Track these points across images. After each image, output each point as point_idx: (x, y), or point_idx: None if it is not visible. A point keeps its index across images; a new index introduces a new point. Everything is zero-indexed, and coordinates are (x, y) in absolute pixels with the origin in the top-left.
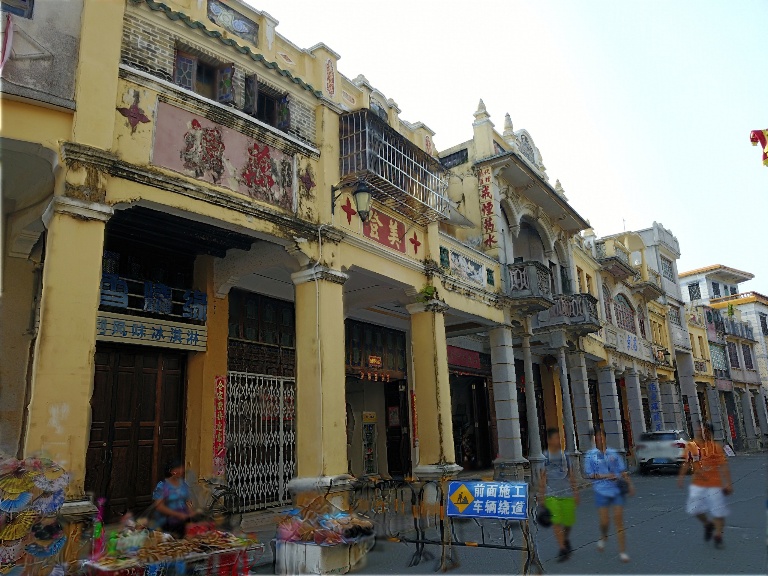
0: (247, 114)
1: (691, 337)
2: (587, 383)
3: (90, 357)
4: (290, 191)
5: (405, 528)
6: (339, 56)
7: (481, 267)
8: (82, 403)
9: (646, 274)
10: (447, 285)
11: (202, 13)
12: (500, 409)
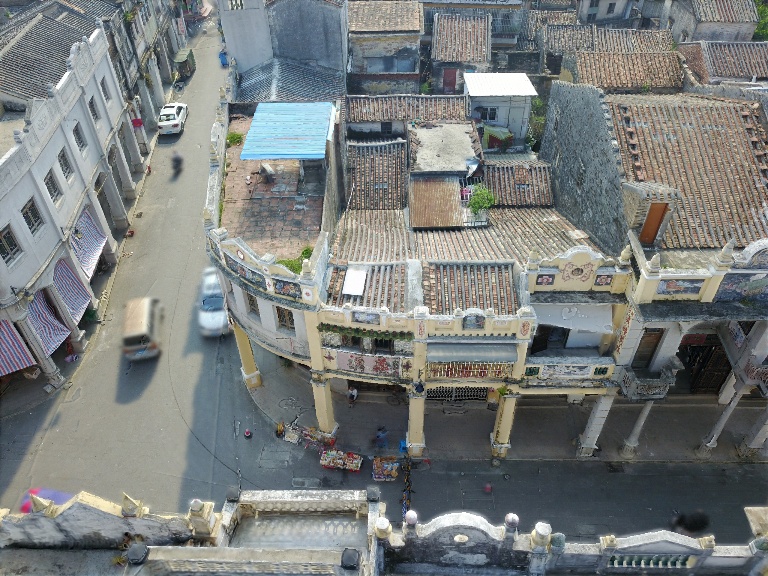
0: (371, 354)
1: None
2: None
3: (326, 411)
4: (398, 370)
5: (456, 458)
6: (428, 319)
7: (590, 366)
8: (326, 418)
9: None
10: (531, 382)
11: (349, 323)
12: (589, 421)
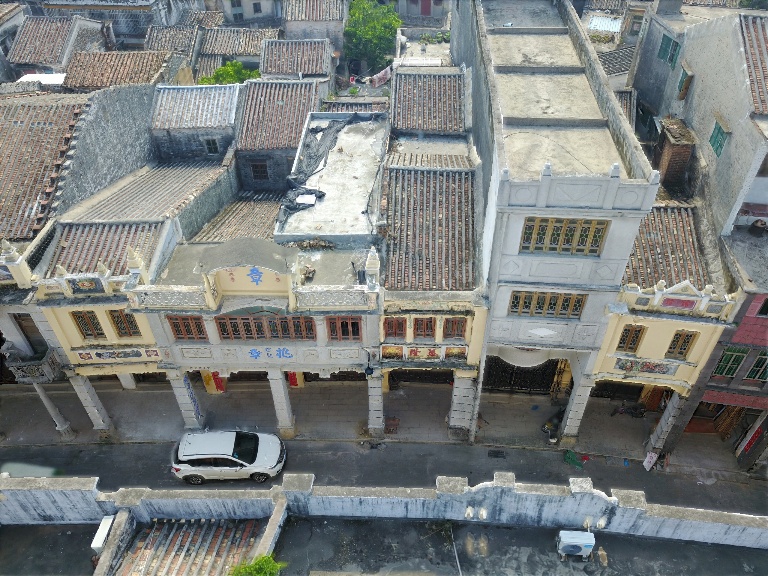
0: None
1: (645, 327)
2: (87, 394)
3: None
4: None
5: None
6: None
7: None
8: None
9: (289, 301)
10: None
11: None
12: None
